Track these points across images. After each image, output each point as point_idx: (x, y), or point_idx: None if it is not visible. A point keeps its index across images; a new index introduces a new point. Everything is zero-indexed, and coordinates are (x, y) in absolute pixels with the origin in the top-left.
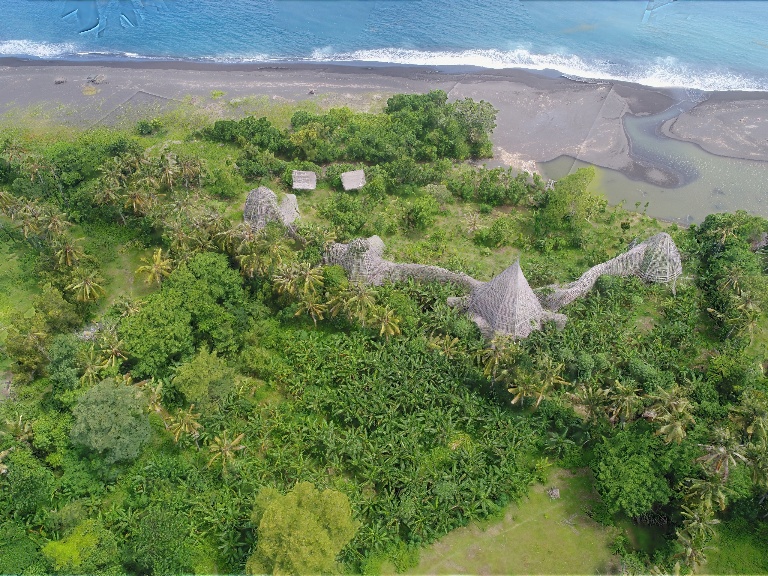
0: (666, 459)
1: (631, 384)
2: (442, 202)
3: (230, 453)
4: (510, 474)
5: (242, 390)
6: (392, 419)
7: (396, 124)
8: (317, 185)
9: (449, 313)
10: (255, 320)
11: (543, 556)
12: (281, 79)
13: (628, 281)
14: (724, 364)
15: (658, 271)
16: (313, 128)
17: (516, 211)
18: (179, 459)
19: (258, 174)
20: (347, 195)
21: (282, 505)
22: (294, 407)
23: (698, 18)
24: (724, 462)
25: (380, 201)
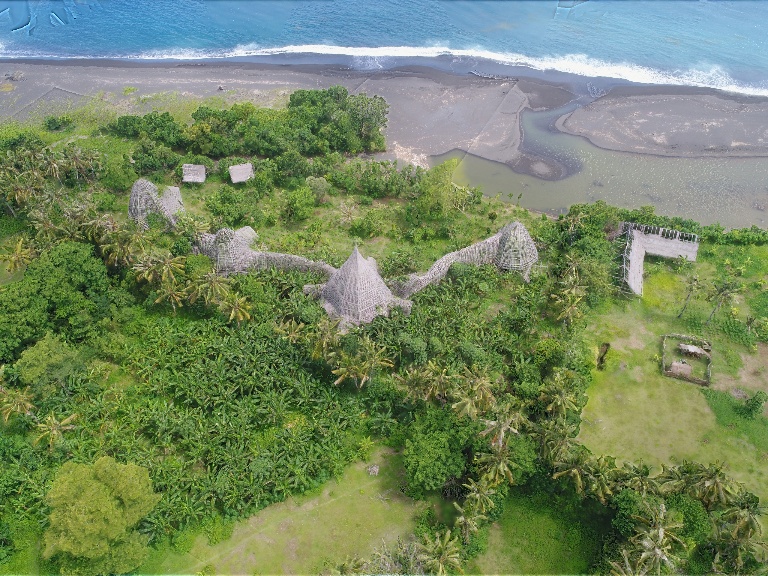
0: (462, 435)
1: (460, 366)
2: (322, 194)
3: (57, 432)
4: (328, 451)
5: (94, 374)
6: (228, 400)
7: (292, 119)
8: (209, 178)
9: (303, 300)
10: (118, 307)
11: (350, 529)
12: (196, 76)
13: (483, 269)
14: (549, 347)
15: (511, 259)
16: (210, 123)
17: (395, 203)
18: (15, 439)
19: (152, 168)
20: (230, 187)
21: (72, 477)
22: (141, 390)
23: (613, 15)
24: (499, 435)
25: (267, 193)
